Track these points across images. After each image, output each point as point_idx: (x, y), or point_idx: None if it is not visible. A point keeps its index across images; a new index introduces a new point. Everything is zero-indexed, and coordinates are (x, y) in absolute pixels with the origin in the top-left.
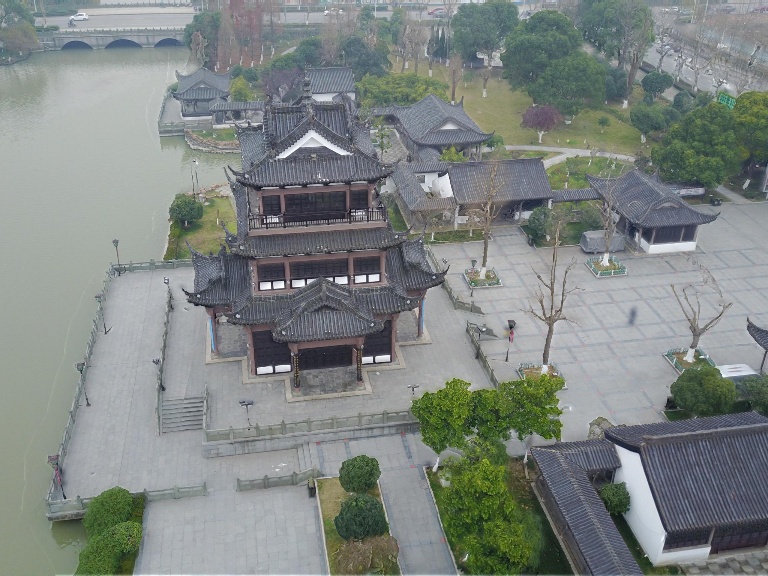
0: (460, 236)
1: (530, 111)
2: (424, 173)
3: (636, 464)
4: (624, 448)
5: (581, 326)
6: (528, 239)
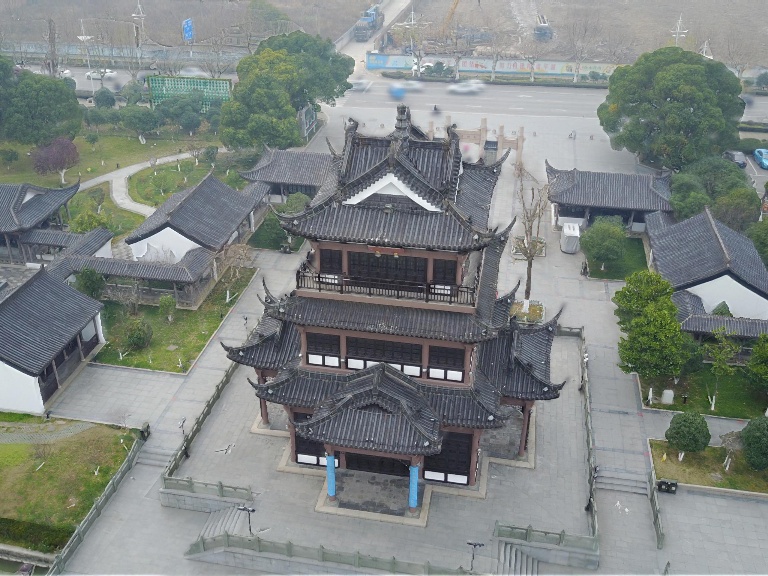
0: (234, 283)
1: (40, 152)
2: (95, 252)
3: (726, 284)
4: (703, 284)
5: None
6: (283, 249)
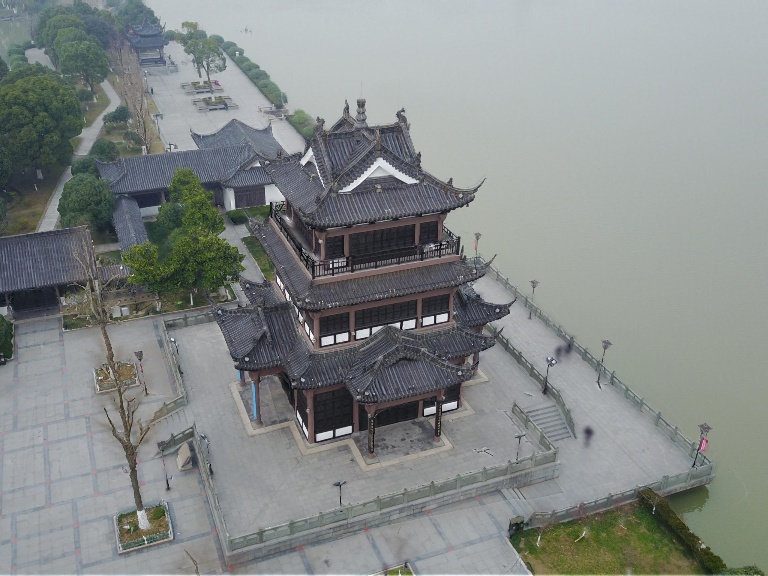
0: None
1: None
2: None
3: None
4: None
5: (32, 453)
6: None
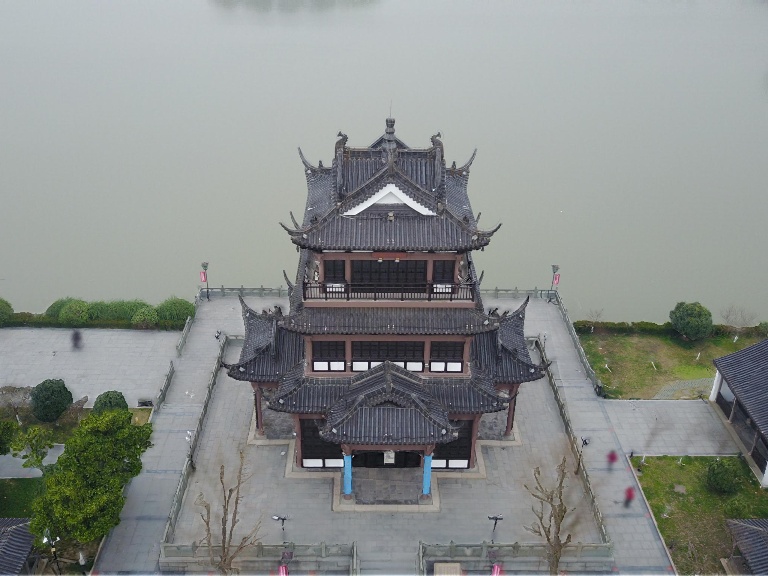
0: None
1: None
2: None
3: None
4: None
5: None
6: None
